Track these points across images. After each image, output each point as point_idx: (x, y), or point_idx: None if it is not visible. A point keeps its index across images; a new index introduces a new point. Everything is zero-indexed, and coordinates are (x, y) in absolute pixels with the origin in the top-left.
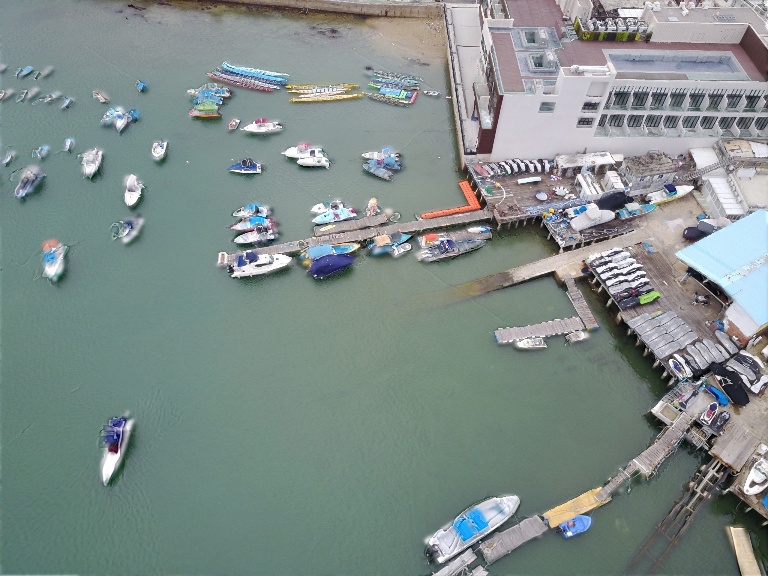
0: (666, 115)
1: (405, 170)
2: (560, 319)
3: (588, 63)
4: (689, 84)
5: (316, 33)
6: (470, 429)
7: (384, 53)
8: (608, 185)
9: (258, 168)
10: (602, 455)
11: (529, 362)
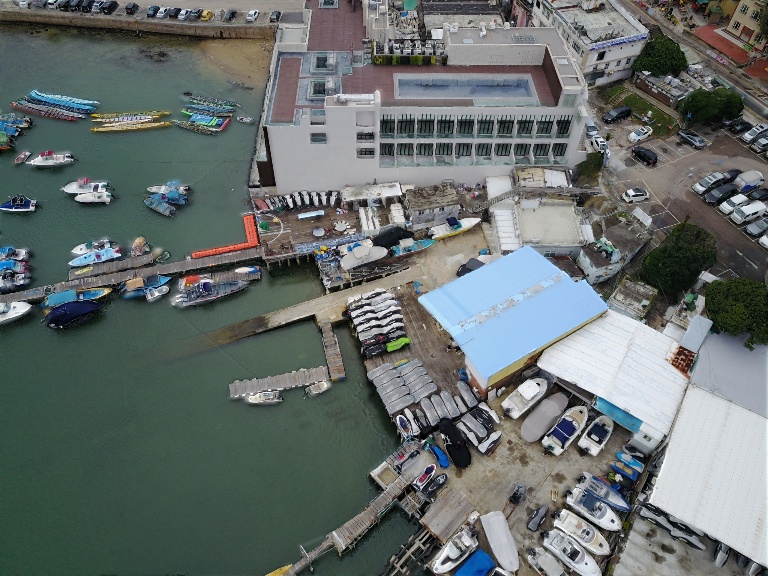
0: (456, 143)
1: (190, 204)
2: (306, 369)
3: (372, 89)
4: (473, 110)
5: (143, 57)
6: (173, 497)
7: (209, 77)
8: (392, 218)
9: (31, 205)
10: (318, 523)
11: (257, 419)
